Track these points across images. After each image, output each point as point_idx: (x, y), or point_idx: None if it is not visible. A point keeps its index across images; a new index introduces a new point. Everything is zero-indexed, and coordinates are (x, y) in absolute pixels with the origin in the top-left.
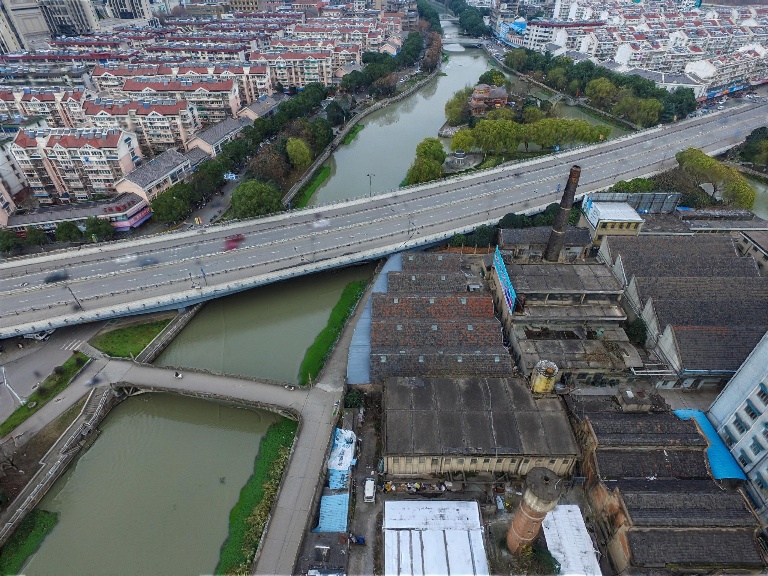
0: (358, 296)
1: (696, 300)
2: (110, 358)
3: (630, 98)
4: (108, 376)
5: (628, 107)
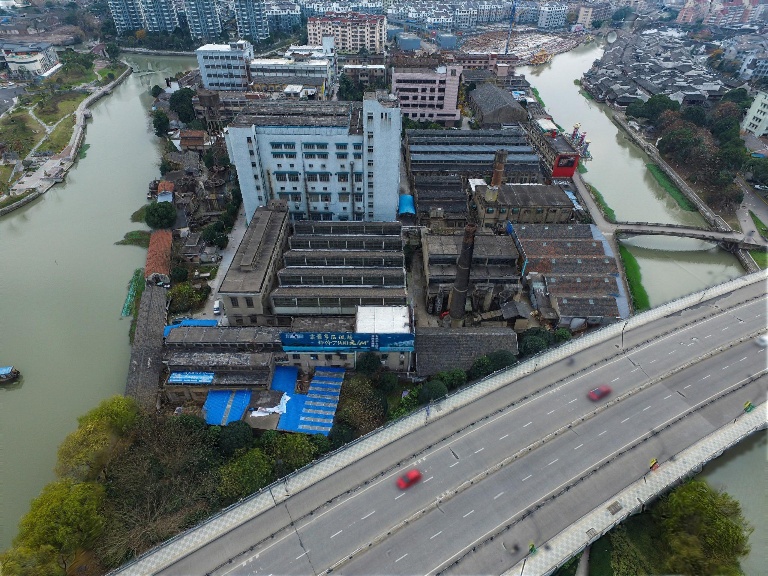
0: (636, 308)
1: None
2: (761, 246)
3: None
4: (745, 238)
5: None
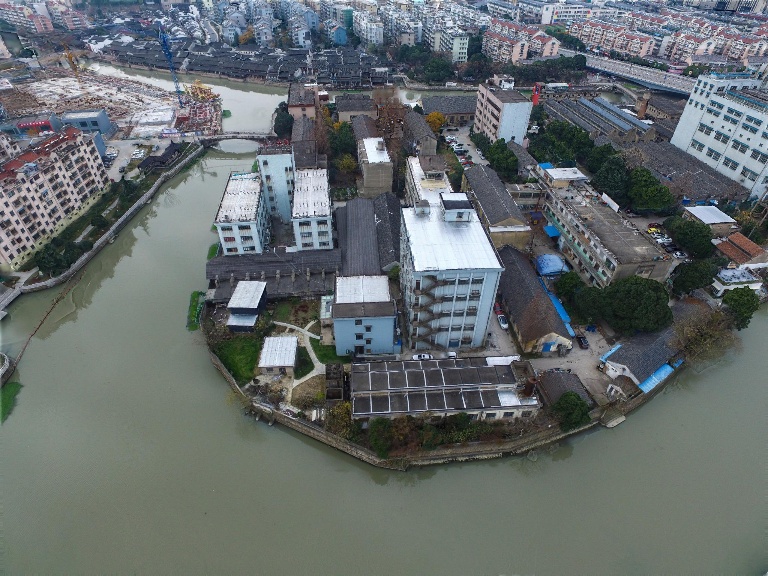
0: None
1: None
2: None
3: None
4: None
5: None
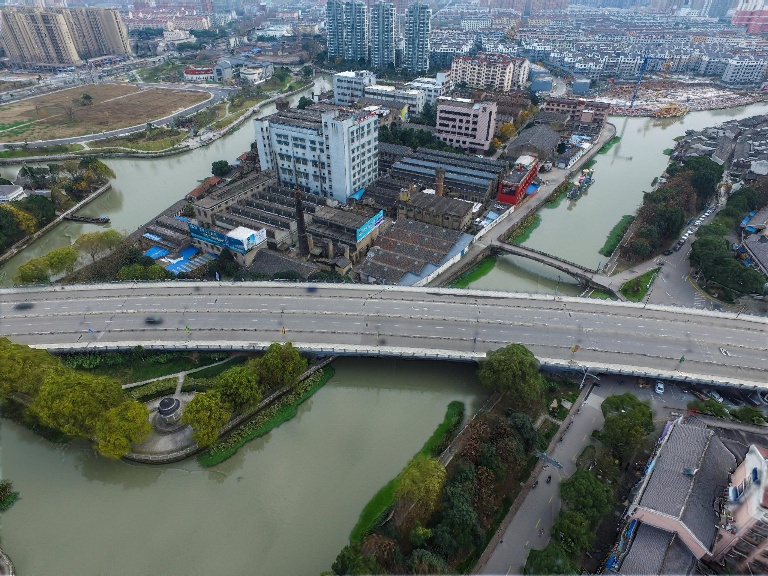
0: None
1: None
2: None
3: None
4: (603, 280)
5: None
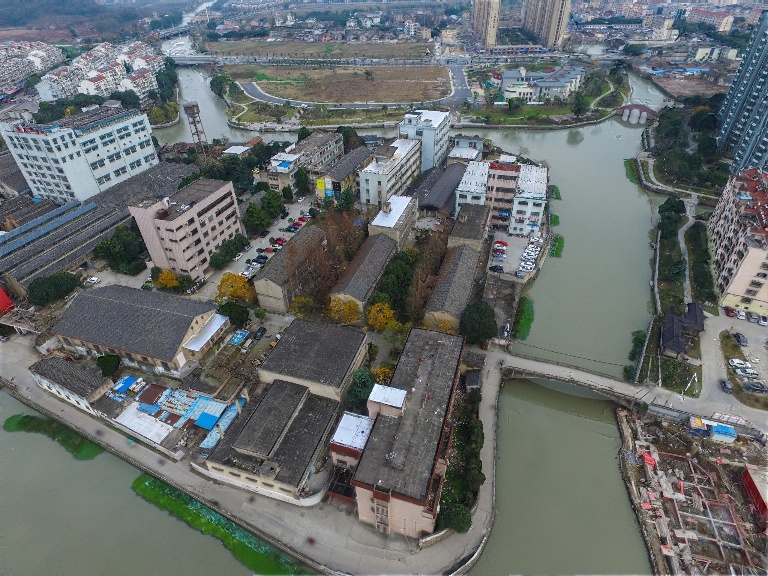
0: None
1: (10, 173)
2: None
3: None
4: None
5: None
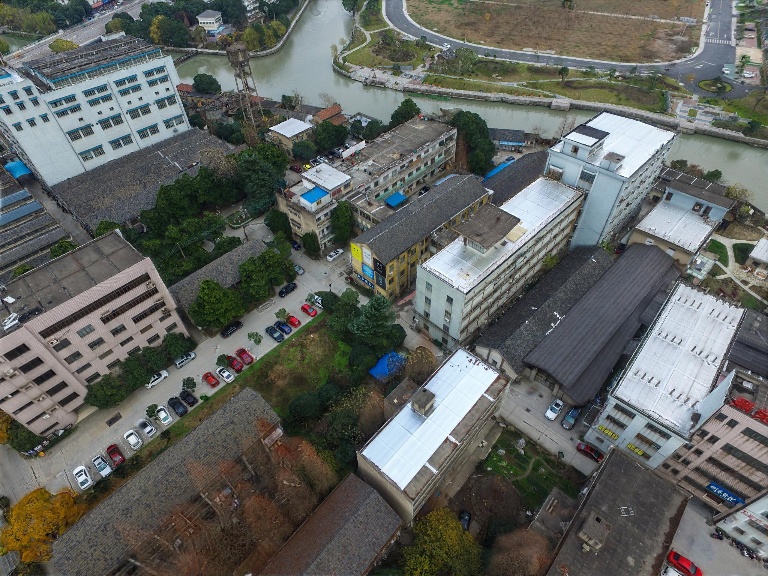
0: None
1: None
2: None
3: (28, 15)
4: None
5: (29, 23)
